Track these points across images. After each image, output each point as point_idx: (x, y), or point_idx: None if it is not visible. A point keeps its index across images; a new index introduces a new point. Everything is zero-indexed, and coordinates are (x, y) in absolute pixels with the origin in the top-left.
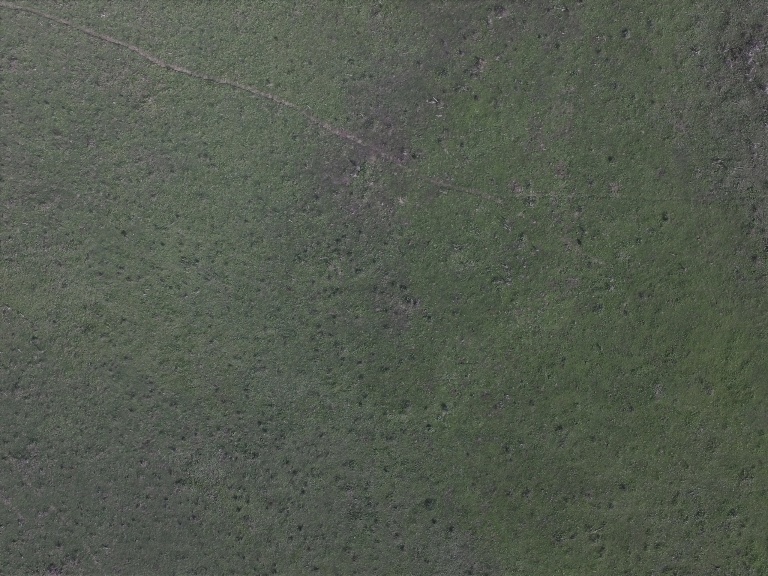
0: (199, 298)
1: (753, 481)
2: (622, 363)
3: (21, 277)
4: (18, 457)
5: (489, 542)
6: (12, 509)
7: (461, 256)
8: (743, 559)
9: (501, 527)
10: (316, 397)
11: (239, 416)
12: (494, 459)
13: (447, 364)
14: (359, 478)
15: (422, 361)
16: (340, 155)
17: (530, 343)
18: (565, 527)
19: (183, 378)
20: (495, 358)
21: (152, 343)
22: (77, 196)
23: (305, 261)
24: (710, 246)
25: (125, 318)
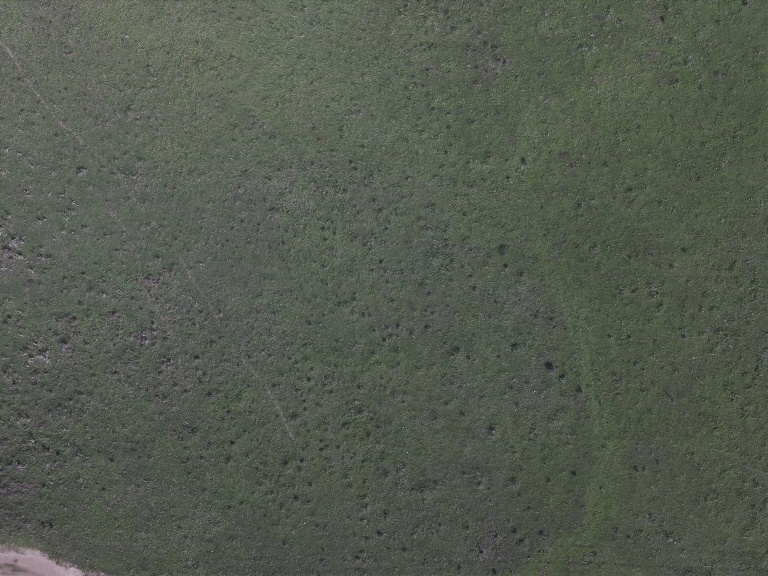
0: (303, 42)
1: None
2: (693, 136)
3: (140, 8)
4: (126, 173)
5: (555, 290)
6: (117, 221)
7: (550, 22)
8: None
9: (567, 277)
10: (405, 143)
11: (332, 154)
12: (566, 213)
13: (529, 122)
14: (439, 221)
15: (506, 117)
16: None
17: (608, 109)
18: (627, 282)
19: (283, 114)
20: (574, 120)
21: (257, 80)
22: None
23: (405, 15)
24: None
25: (233, 55)
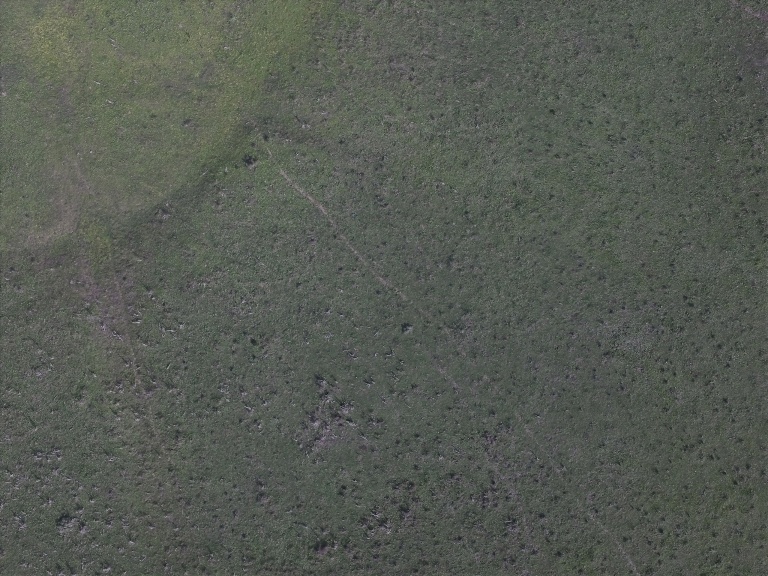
0: (625, 176)
1: None
2: None
3: (454, 153)
4: (454, 327)
5: None
6: (447, 378)
7: None
8: None
9: None
10: (739, 273)
11: (665, 291)
12: None
13: None
14: None
15: None
16: (762, 37)
17: None
18: None
19: (611, 253)
20: None
21: (580, 219)
22: (506, 75)
23: (730, 140)
24: None
25: (553, 194)
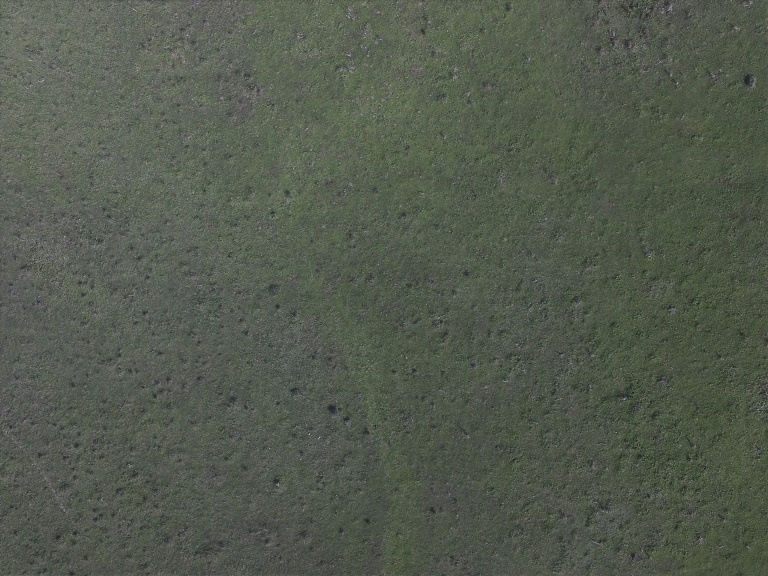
0: (44, 87)
1: (596, 269)
2: (466, 152)
3: None
4: None
5: (333, 327)
6: None
7: (305, 45)
8: (586, 346)
9: (345, 313)
10: (161, 185)
11: (84, 203)
12: (338, 246)
13: (291, 152)
14: (203, 264)
15: (266, 149)
16: None
17: (374, 132)
18: (409, 313)
19: (28, 166)
20: (339, 146)
21: None
22: None
23: (149, 50)
24: (554, 38)
25: None
